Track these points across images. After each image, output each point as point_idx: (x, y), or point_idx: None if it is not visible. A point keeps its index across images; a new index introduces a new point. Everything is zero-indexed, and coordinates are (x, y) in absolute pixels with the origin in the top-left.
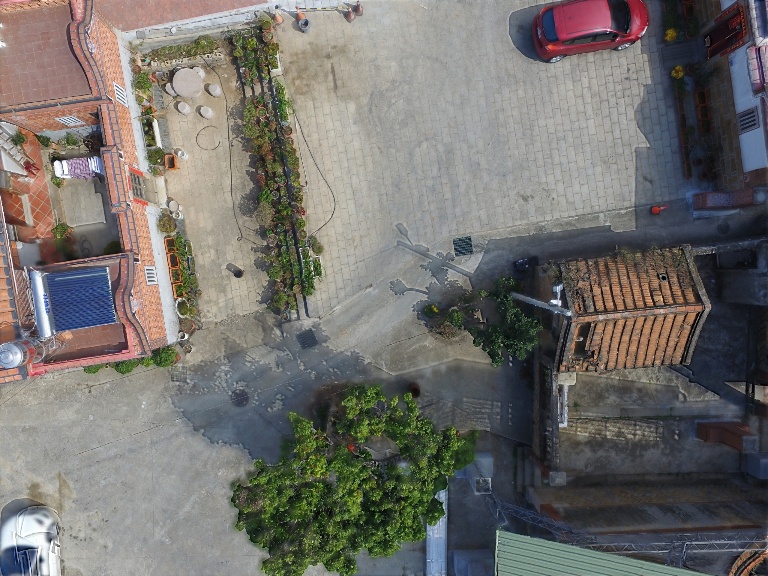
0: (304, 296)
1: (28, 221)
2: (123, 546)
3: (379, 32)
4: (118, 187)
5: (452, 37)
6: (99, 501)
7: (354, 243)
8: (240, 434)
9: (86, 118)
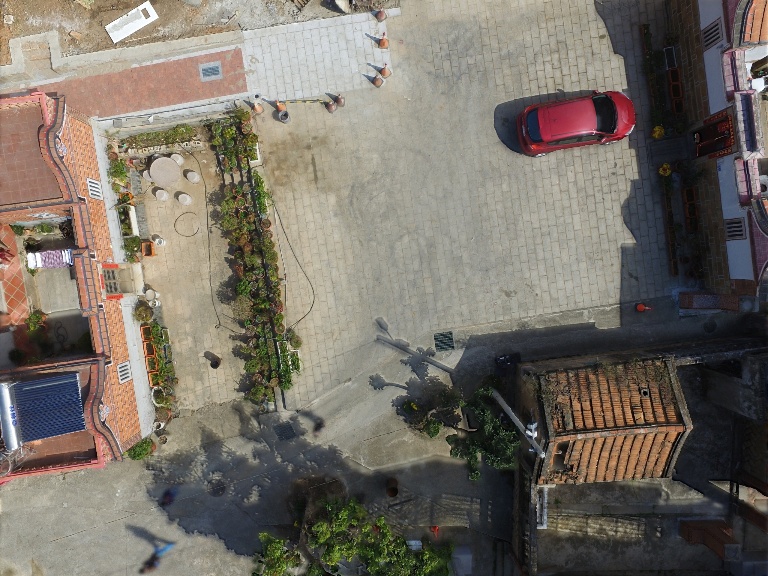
0: (282, 388)
1: (2, 308)
2: None
3: (361, 123)
4: (89, 291)
5: (436, 129)
6: None
7: (333, 336)
8: (216, 524)
9: (59, 213)
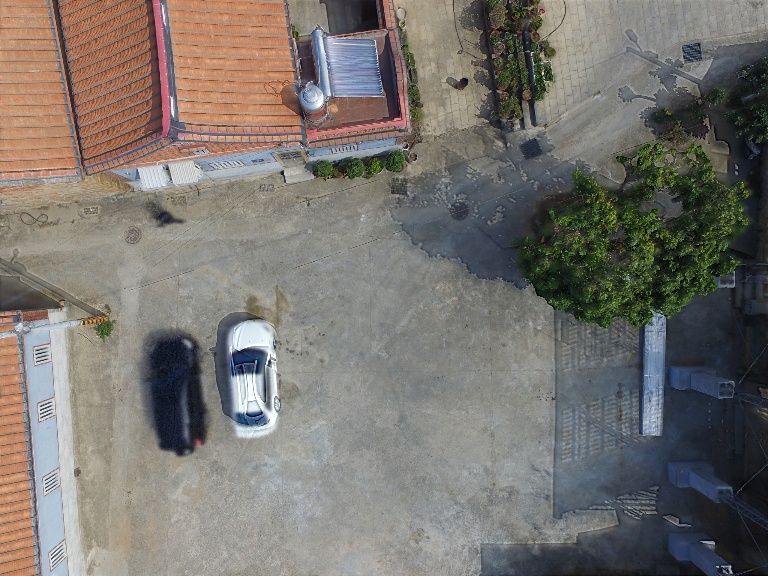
0: (531, 104)
1: None
2: (339, 360)
3: None
4: None
5: None
6: (316, 315)
7: (583, 49)
8: (458, 248)
9: None
